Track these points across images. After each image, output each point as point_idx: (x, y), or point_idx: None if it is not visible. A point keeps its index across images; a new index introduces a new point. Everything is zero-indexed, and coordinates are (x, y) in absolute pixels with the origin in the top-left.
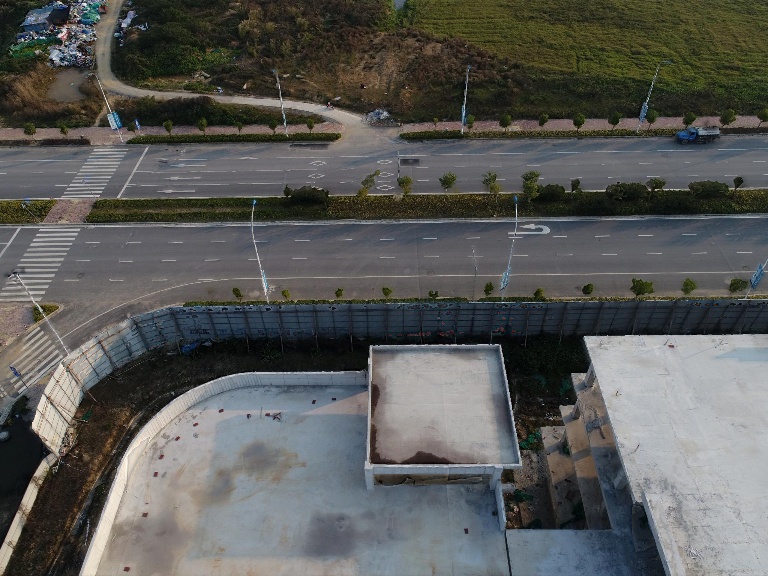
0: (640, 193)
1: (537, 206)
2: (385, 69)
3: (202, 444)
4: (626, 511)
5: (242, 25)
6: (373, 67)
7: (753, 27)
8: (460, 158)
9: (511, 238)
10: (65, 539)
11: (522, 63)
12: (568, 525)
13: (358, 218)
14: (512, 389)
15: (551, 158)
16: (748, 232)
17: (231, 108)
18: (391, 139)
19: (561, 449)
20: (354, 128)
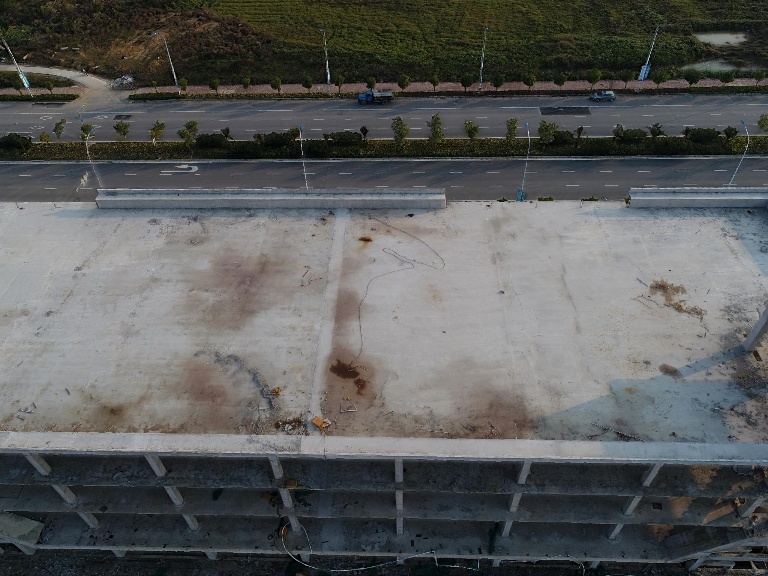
0: (285, 141)
1: (198, 151)
2: (151, 43)
3: None
4: None
5: (45, 5)
6: (143, 41)
7: (507, 10)
8: (166, 114)
9: (161, 175)
10: None
11: (276, 39)
12: None
13: (46, 159)
14: None
15: (242, 115)
16: (359, 172)
17: (1, 74)
18: (121, 99)
19: None
20: (96, 91)
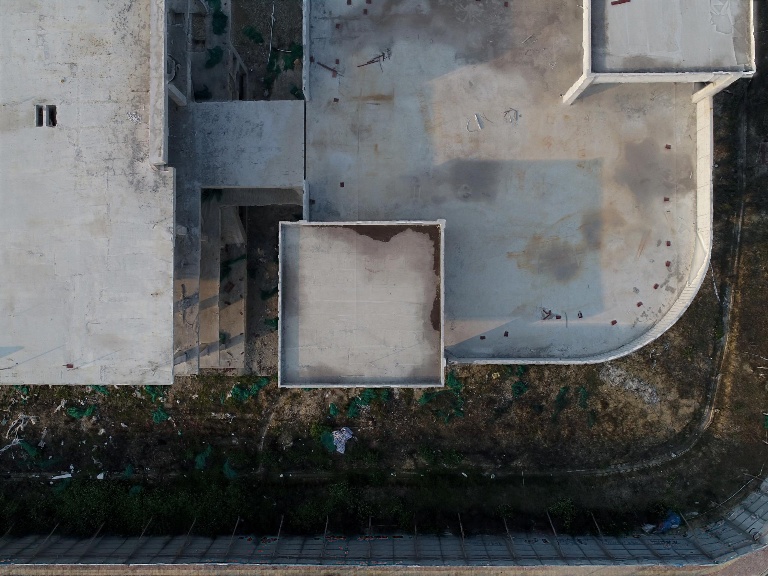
0: None
1: None
2: None
3: (627, 279)
4: (182, 205)
5: None
6: None
7: None
8: None
9: None
10: (735, 281)
11: None
12: (238, 257)
13: None
14: (266, 454)
15: None
16: None
17: None
18: None
19: (227, 338)
20: None
